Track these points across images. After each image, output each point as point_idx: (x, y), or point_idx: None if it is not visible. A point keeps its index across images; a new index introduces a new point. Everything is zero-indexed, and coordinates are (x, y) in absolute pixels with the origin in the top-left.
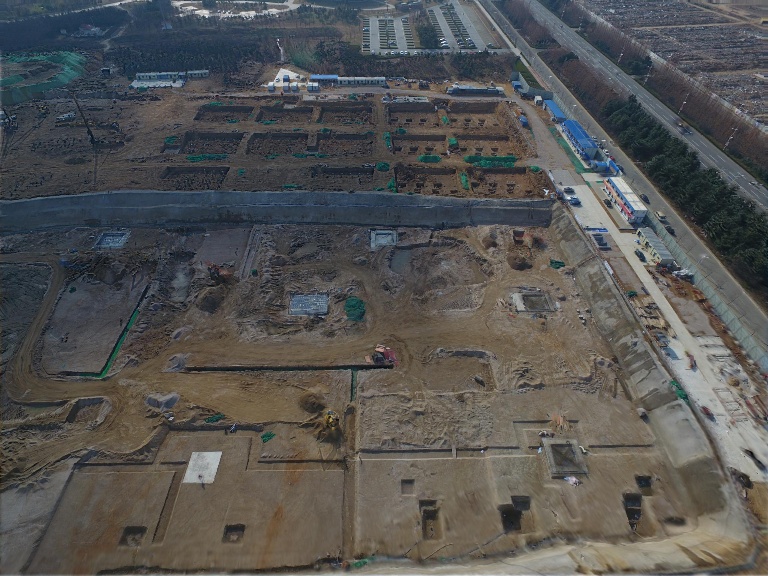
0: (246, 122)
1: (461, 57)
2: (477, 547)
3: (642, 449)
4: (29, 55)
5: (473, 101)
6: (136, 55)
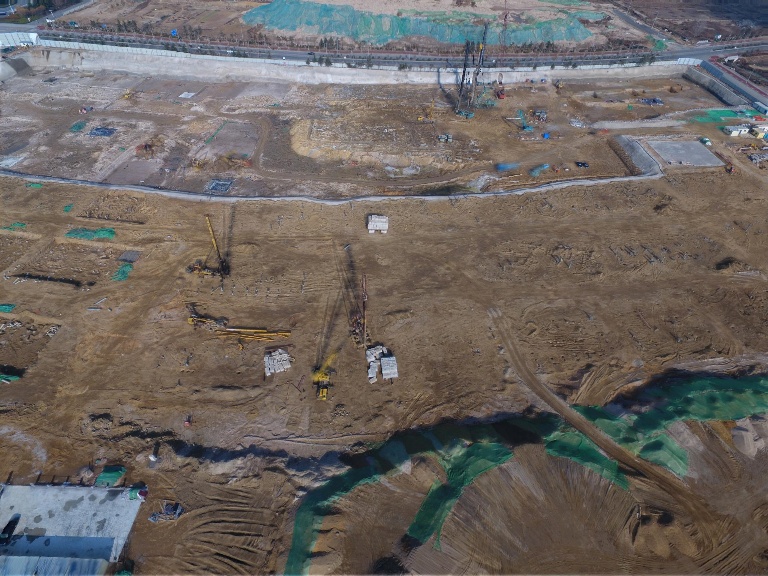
0: None
1: None
2: (107, 74)
3: (19, 79)
4: None
5: None
6: None
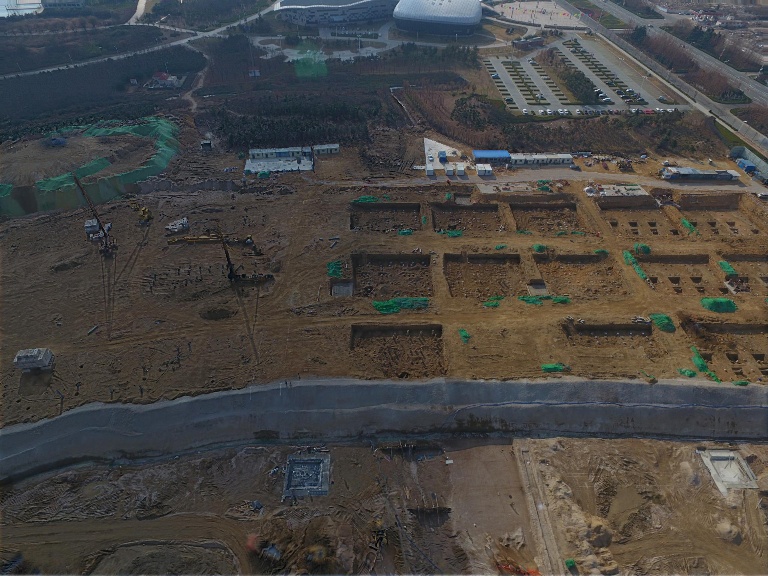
0: (423, 233)
1: (646, 120)
2: None
3: None
4: (109, 125)
5: (707, 193)
6: (237, 119)
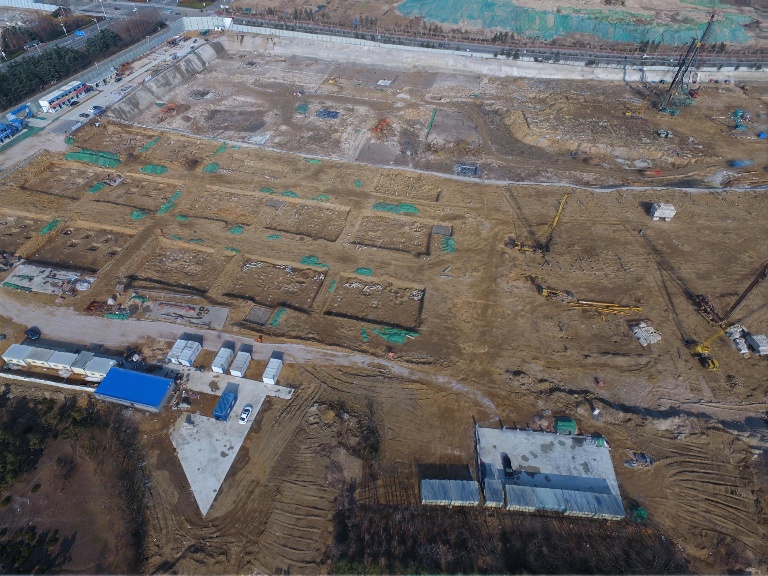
0: (343, 267)
1: None
2: None
3: None
4: None
5: None
6: None
